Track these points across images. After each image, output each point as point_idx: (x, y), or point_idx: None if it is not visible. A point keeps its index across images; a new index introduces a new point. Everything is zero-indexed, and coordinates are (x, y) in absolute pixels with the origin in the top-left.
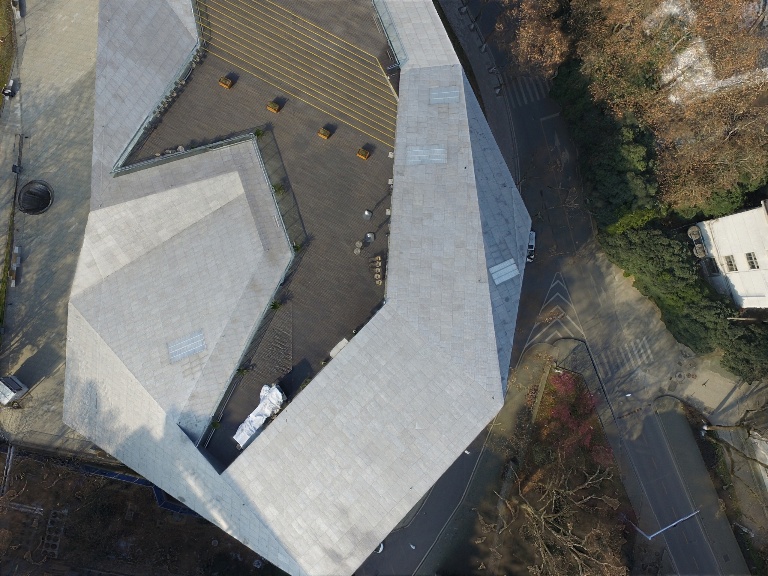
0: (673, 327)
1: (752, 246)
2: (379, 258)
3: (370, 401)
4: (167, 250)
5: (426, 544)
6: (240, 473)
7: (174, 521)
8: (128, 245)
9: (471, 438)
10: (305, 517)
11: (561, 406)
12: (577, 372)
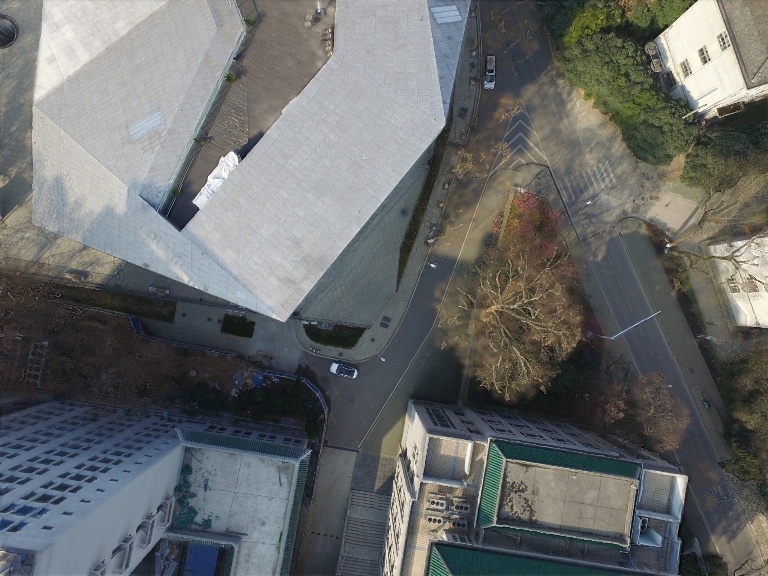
0: (632, 142)
1: (703, 39)
2: (329, 30)
3: (320, 143)
4: (125, 43)
5: (399, 371)
6: (199, 227)
7: (152, 354)
8: (86, 38)
9: (415, 158)
10: (260, 254)
11: (526, 229)
12: (541, 196)
